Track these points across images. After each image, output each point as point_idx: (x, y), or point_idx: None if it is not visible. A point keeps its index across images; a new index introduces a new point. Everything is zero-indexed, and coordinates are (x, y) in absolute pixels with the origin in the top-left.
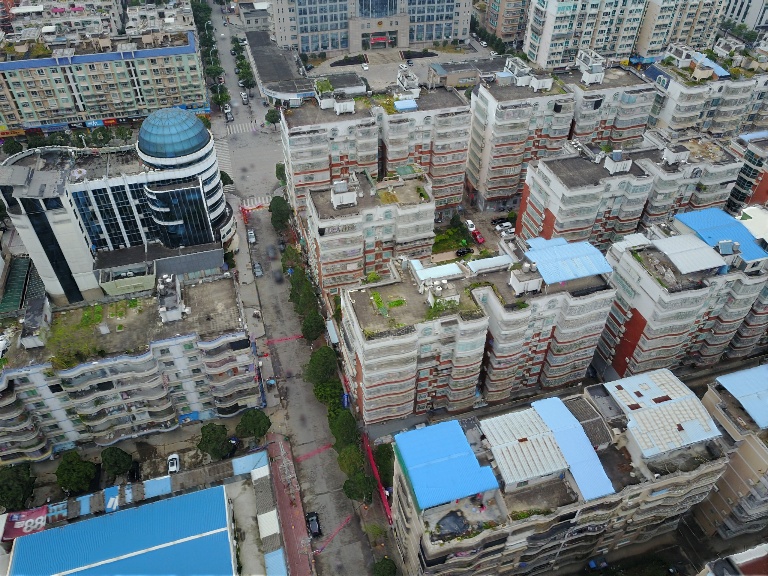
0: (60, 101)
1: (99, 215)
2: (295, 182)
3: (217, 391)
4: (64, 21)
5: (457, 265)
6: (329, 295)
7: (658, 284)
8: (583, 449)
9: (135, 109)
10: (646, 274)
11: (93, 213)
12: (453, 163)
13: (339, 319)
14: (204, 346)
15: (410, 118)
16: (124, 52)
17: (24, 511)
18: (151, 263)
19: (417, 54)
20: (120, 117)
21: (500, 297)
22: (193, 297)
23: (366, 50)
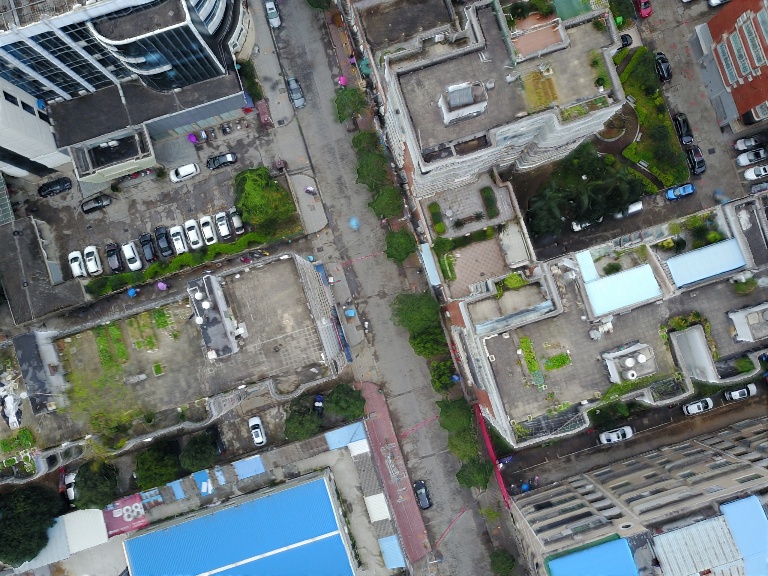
0: None
1: (29, 70)
2: None
3: None
4: None
5: (650, 267)
6: (422, 200)
7: None
8: None
9: None
10: None
11: (18, 70)
12: None
13: (441, 254)
14: None
15: None
16: None
17: (116, 500)
18: (139, 127)
19: None
20: None
21: (713, 348)
22: (243, 302)
23: None
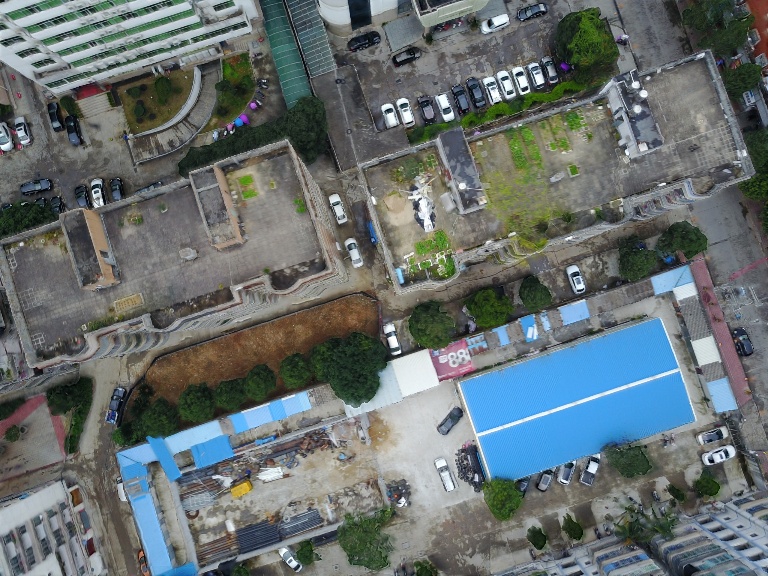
0: None
1: None
2: None
3: (652, 212)
4: None
5: None
6: None
7: None
8: None
9: None
10: None
11: None
12: None
13: None
14: (697, 197)
15: None
16: None
17: None
18: None
19: None
20: None
21: None
22: (656, 103)
23: None
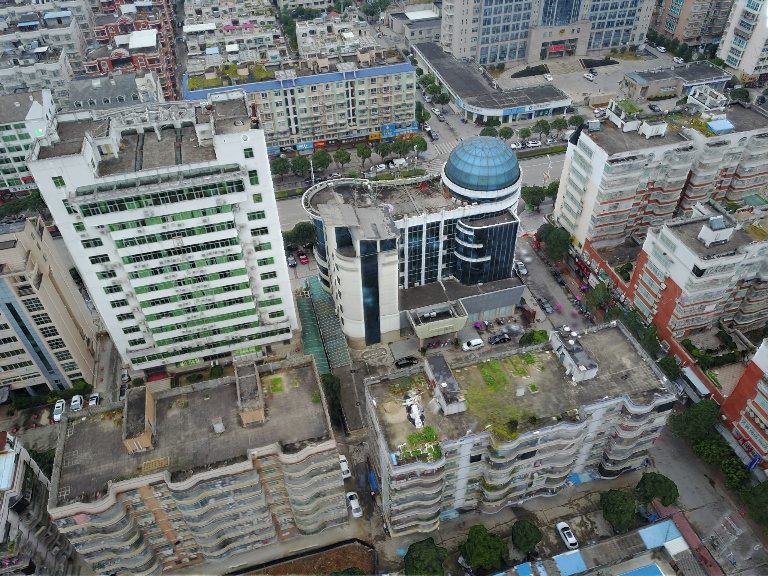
0: (277, 124)
1: (407, 253)
2: (598, 212)
3: (617, 454)
4: (237, 39)
5: None
6: (674, 338)
7: None
8: None
9: (346, 130)
10: None
11: (402, 251)
12: (753, 186)
13: (706, 367)
14: (638, 410)
15: (726, 140)
16: (346, 72)
17: None
18: (455, 302)
19: (598, 62)
20: (330, 139)
21: None
22: (588, 350)
23: (543, 60)
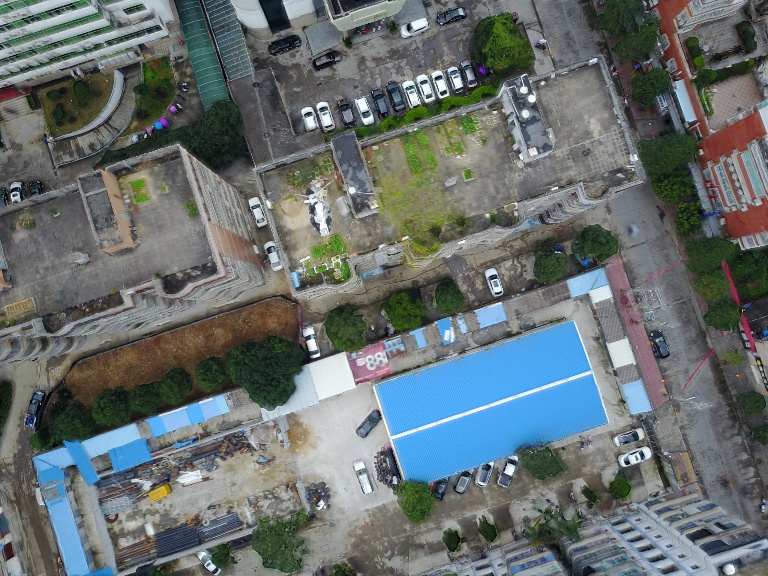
0: None
1: None
2: None
3: (560, 216)
4: None
5: None
6: (679, 34)
7: None
8: None
9: None
10: None
11: None
12: None
13: (703, 86)
14: (591, 201)
15: None
16: None
17: (360, 349)
18: None
19: None
20: None
21: None
22: (550, 108)
23: None
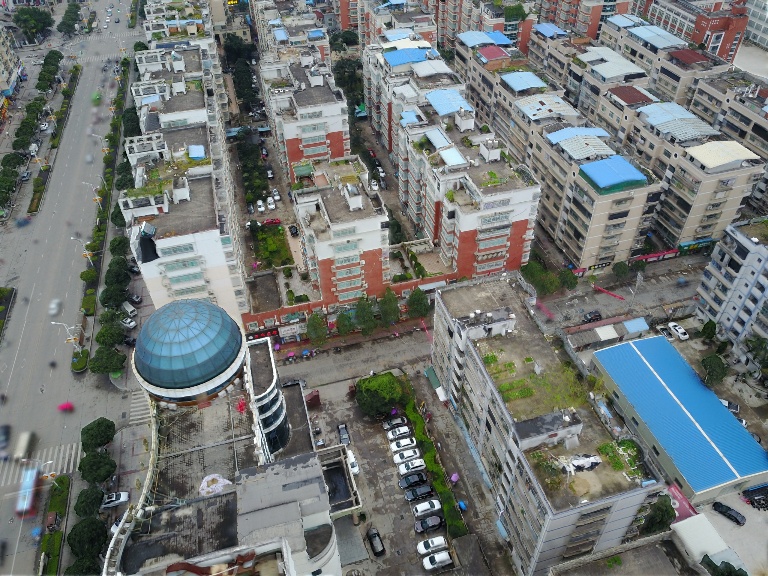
0: None
1: None
2: (240, 282)
3: None
4: None
5: None
6: None
7: (455, 85)
8: (582, 130)
9: None
10: (444, 88)
11: None
12: None
13: None
14: None
15: None
16: None
17: None
18: None
19: None
20: None
21: None
22: None
23: None
